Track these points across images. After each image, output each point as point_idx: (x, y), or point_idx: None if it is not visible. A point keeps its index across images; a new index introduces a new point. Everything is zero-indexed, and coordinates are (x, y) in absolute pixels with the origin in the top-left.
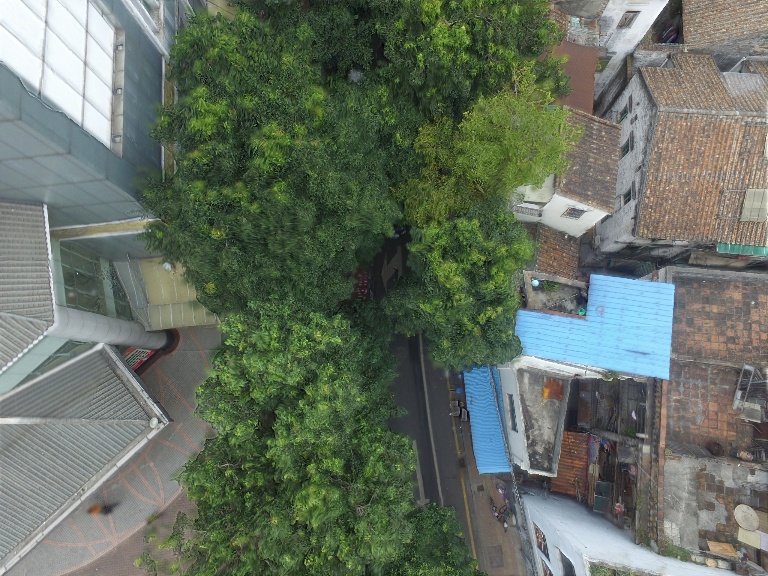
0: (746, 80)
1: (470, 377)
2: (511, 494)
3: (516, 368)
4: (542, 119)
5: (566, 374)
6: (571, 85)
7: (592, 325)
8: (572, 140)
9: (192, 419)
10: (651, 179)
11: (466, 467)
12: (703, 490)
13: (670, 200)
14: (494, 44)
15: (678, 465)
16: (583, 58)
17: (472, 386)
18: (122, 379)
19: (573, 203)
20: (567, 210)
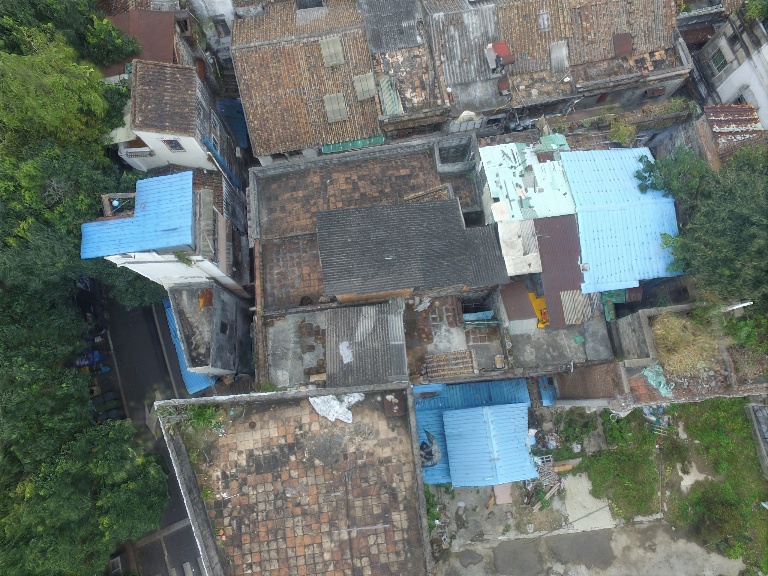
0: (314, 13)
1: (171, 315)
2: None
3: (166, 287)
4: (8, 60)
5: (205, 280)
6: (150, 44)
7: (137, 219)
8: (145, 85)
9: None
10: (249, 106)
11: None
12: (305, 337)
13: (271, 120)
14: (8, 16)
15: (284, 324)
16: (160, 21)
17: (174, 322)
18: None
19: (158, 135)
20: (165, 144)
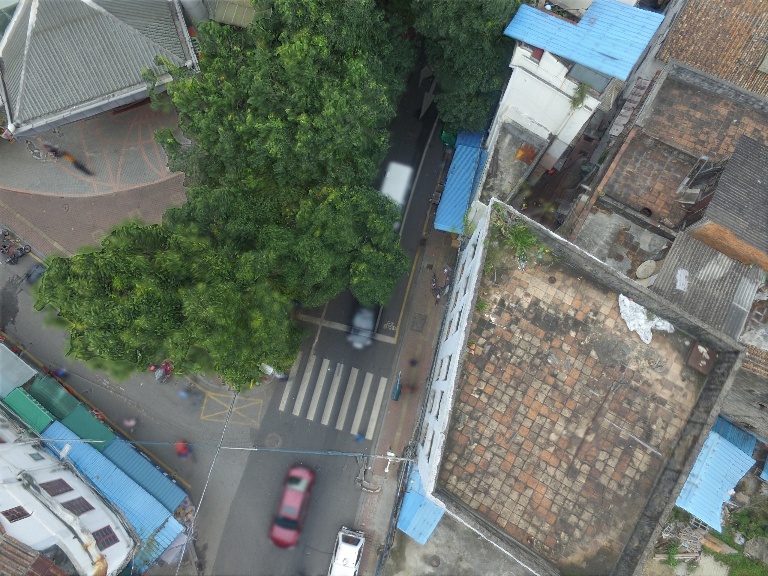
0: None
1: (461, 152)
2: None
3: (503, 120)
4: None
5: (543, 136)
6: None
7: (580, 29)
8: None
9: None
10: (692, 5)
11: (425, 246)
12: (619, 244)
13: (701, 32)
14: None
15: (606, 219)
16: None
17: (459, 160)
18: (177, 29)
19: None
20: None
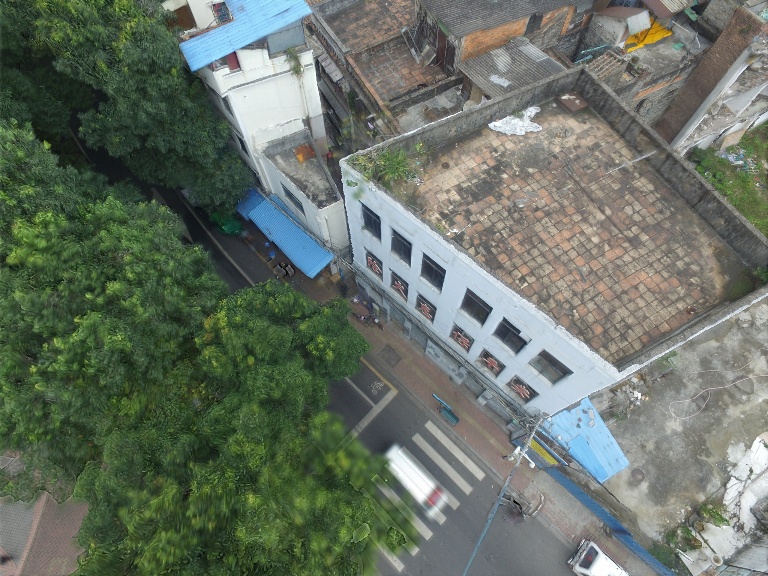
0: None
1: (256, 216)
2: (361, 291)
3: (260, 150)
4: None
5: (300, 128)
6: None
7: (240, 19)
8: None
9: (9, 458)
10: None
11: None
12: None
13: None
14: None
15: (408, 117)
16: None
17: (262, 221)
18: None
19: None
20: (213, 14)
